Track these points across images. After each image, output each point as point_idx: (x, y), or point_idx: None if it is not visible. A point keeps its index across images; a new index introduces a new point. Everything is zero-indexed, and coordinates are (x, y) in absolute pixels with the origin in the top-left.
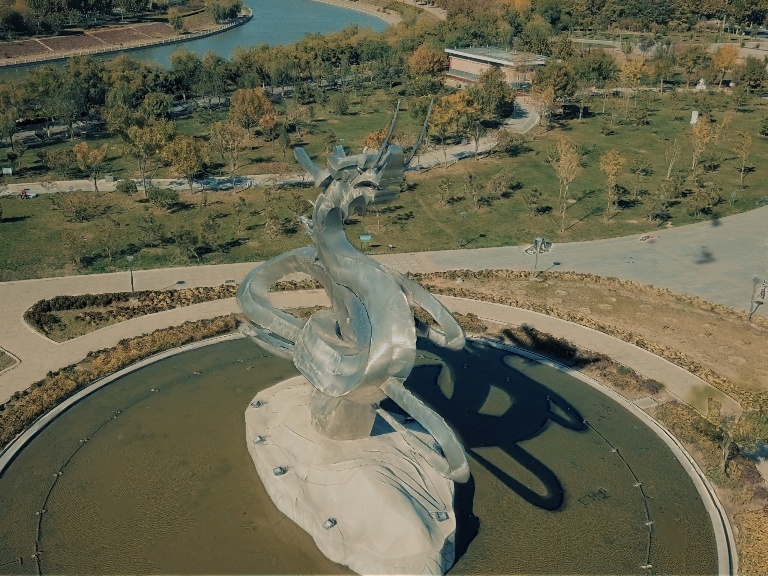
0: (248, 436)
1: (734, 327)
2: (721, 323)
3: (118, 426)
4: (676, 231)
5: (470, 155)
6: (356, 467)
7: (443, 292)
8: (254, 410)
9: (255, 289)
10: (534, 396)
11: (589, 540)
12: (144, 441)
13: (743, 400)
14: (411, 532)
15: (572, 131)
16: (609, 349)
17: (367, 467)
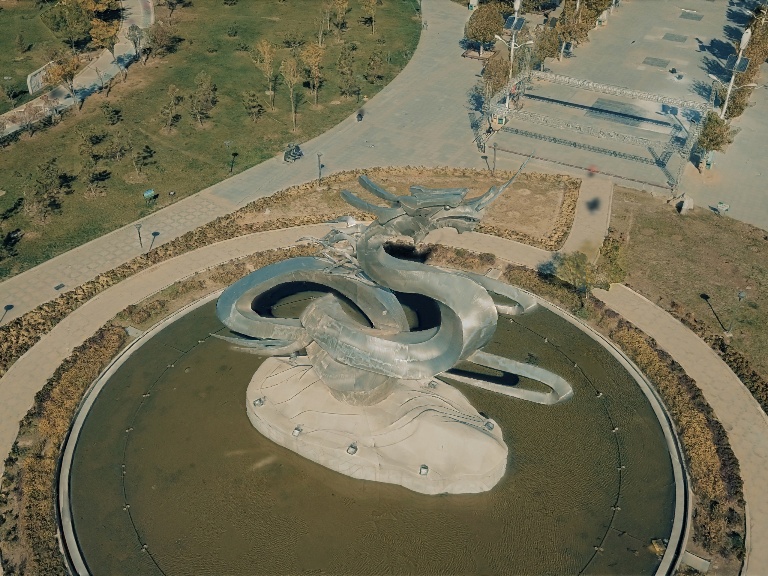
0: (276, 433)
1: (489, 186)
2: (479, 185)
3: (139, 479)
4: (374, 103)
5: (131, 60)
6: (415, 420)
7: (265, 228)
8: (262, 409)
9: (242, 307)
10: (423, 299)
11: None
12: (179, 480)
13: (546, 247)
14: (492, 448)
15: (195, 6)
16: (433, 237)
17: (426, 416)
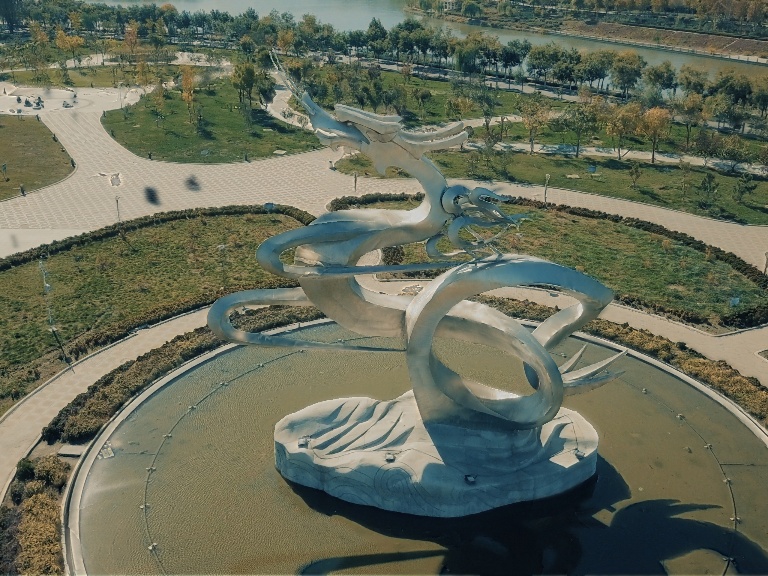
0: None
1: None
2: None
3: None
4: None
5: None
6: None
7: None
8: None
9: None
10: None
11: (246, 575)
12: None
13: None
14: None
15: None
16: None
17: (366, 398)
